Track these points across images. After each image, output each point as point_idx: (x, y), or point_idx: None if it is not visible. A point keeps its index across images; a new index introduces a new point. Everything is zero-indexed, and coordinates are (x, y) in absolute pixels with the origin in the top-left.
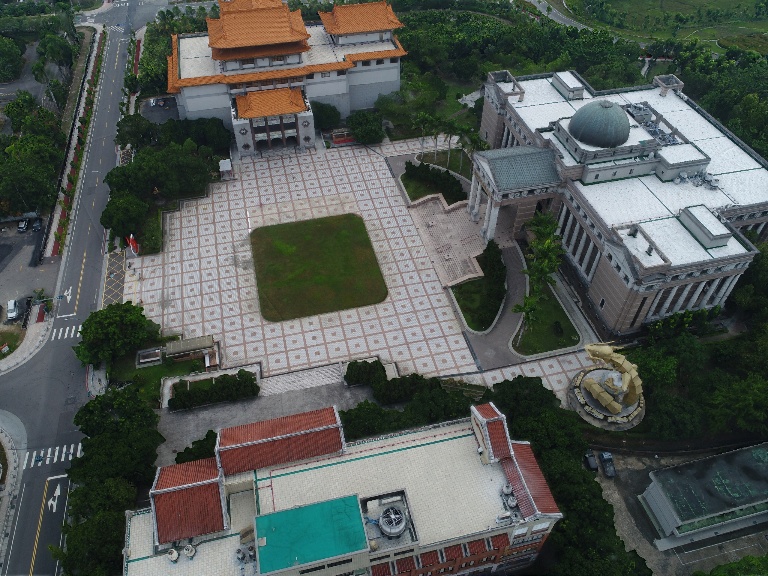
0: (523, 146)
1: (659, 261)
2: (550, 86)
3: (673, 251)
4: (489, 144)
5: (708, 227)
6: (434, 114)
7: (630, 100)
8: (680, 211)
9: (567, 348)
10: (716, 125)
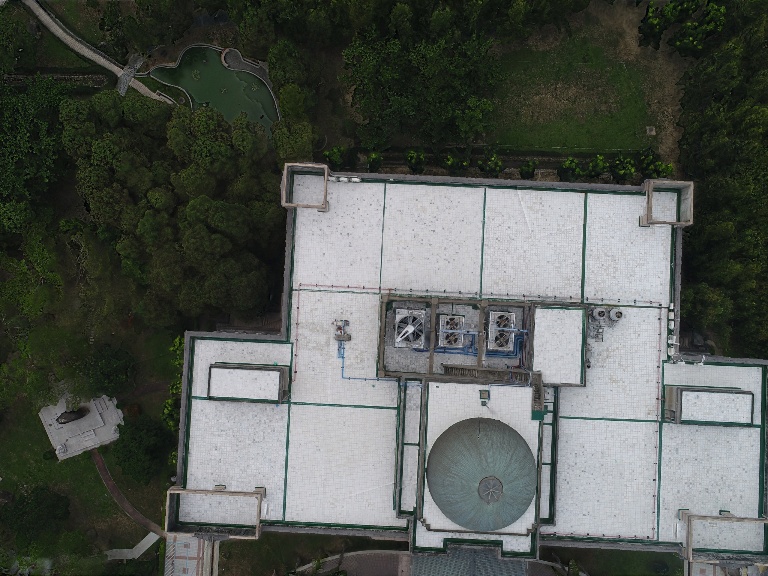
0: (416, 566)
1: (743, 508)
2: (225, 406)
3: (730, 475)
4: (341, 575)
5: (731, 419)
6: (143, 569)
7: (323, 282)
8: (652, 406)
9: (685, 567)
10: (452, 184)
